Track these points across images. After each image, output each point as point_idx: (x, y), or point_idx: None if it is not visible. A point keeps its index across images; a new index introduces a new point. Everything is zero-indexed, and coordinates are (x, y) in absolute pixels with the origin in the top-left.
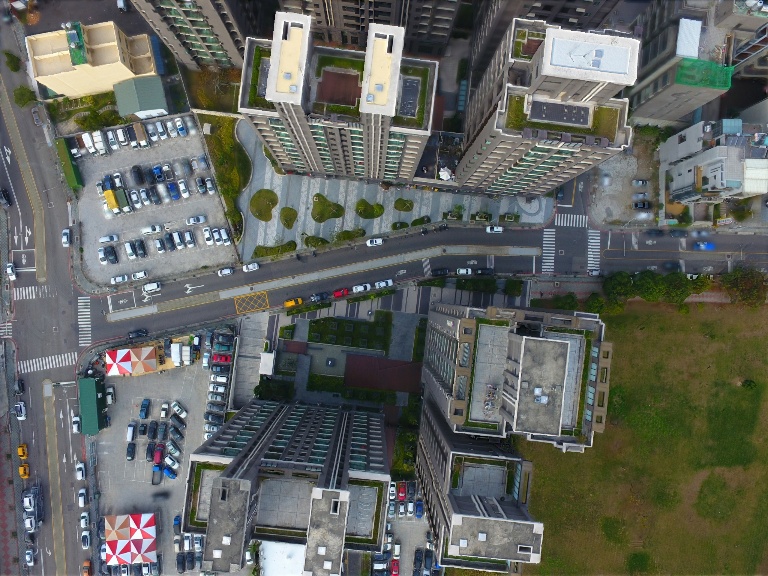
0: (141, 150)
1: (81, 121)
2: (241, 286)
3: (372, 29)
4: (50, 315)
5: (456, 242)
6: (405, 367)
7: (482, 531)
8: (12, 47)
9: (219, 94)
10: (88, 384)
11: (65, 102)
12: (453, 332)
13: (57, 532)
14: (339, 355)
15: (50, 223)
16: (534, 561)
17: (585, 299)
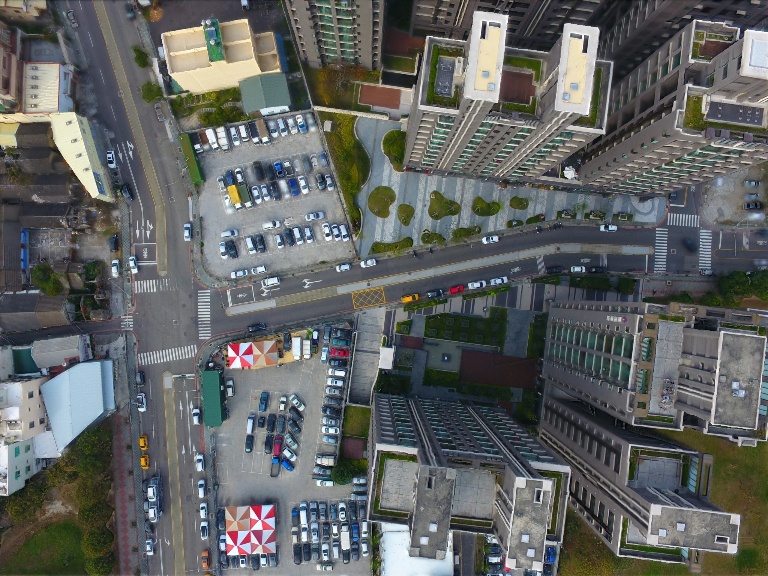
0: (261, 146)
1: (204, 117)
2: (358, 281)
3: (568, 29)
4: (171, 308)
5: (570, 240)
6: (519, 363)
7: (680, 521)
8: (135, 43)
9: (339, 92)
10: (212, 376)
11: (188, 98)
12: (625, 327)
13: (176, 522)
14: (454, 351)
15: (171, 217)
16: (731, 551)
17: (697, 298)
